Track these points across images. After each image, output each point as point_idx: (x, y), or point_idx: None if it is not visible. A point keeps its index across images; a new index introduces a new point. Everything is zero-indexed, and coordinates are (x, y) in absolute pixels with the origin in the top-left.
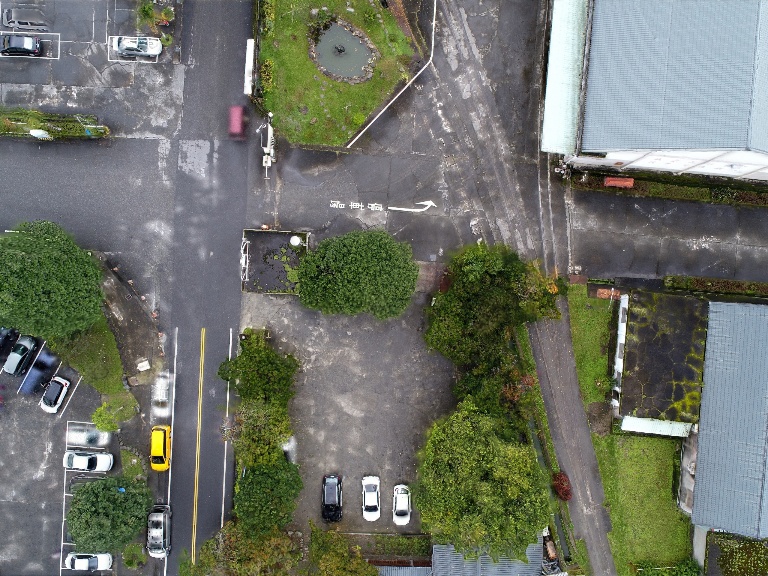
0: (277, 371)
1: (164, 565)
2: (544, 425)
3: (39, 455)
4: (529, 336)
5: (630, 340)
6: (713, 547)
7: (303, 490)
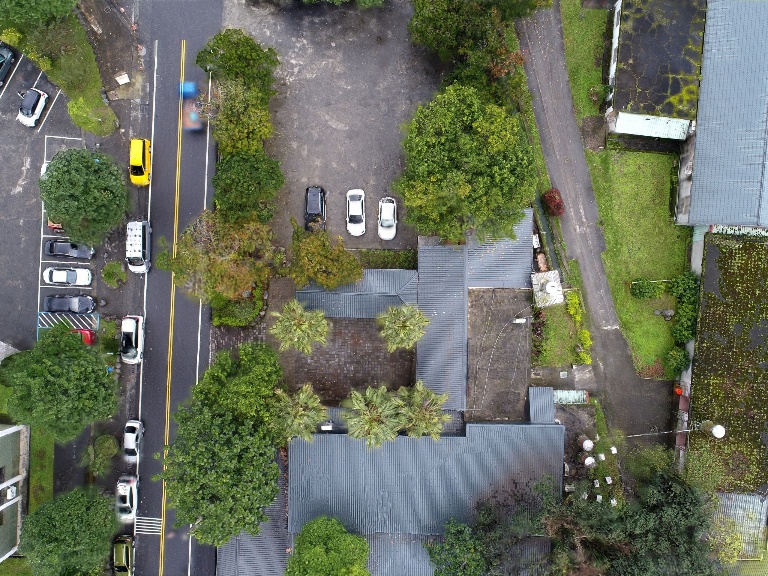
0: (256, 54)
1: (144, 284)
2: (535, 141)
3: (17, 170)
4: (520, 48)
5: (624, 32)
6: (711, 248)
7: (286, 206)
